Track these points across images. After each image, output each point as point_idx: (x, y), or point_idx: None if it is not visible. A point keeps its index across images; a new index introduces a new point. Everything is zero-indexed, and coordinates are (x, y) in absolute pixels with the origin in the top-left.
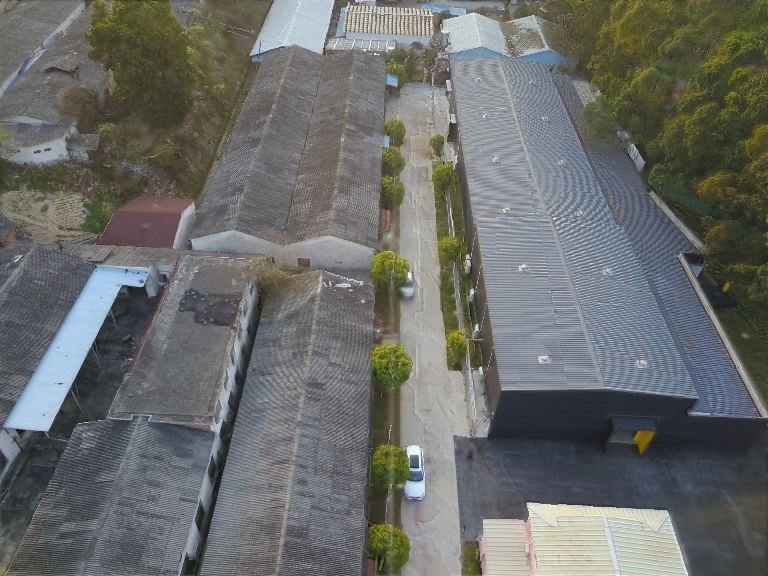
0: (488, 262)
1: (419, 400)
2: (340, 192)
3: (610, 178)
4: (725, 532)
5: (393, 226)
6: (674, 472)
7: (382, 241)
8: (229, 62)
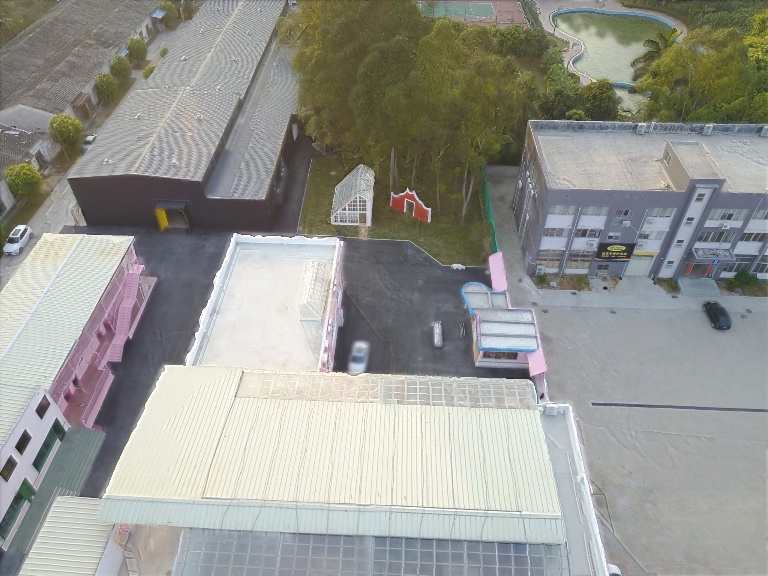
0: (118, 114)
1: (53, 207)
2: (49, 80)
3: (280, 72)
4: (216, 271)
5: (107, 112)
6: (207, 242)
7: (90, 120)
8: (37, 6)
